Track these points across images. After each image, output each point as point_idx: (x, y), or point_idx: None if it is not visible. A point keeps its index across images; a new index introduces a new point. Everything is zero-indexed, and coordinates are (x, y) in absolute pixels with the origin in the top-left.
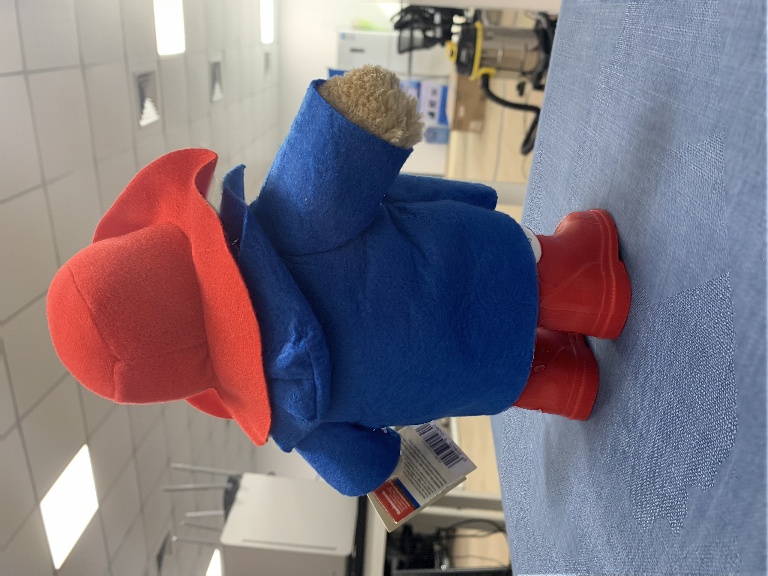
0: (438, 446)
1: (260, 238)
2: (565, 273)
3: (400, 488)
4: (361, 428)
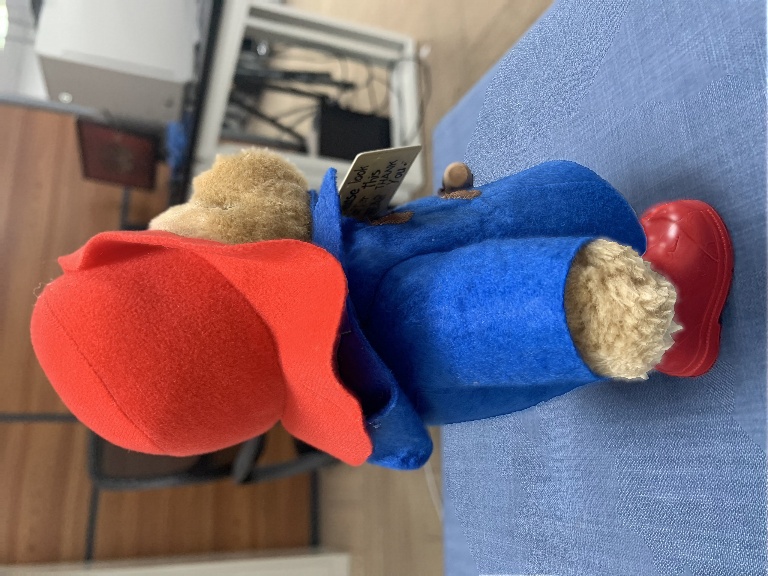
0: None
1: (402, 409)
2: None
3: None
4: None
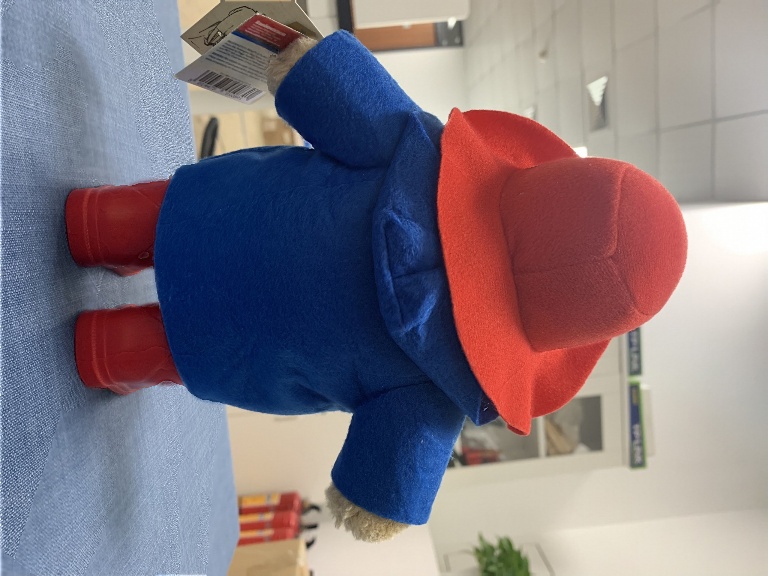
0: (229, 85)
1: (462, 407)
2: (156, 378)
3: (264, 43)
4: (330, 158)
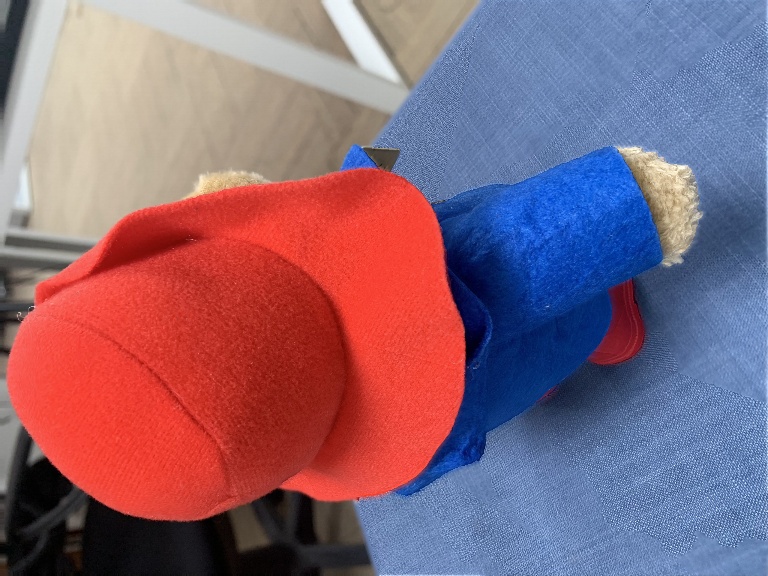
0: None
1: (487, 351)
2: (612, 321)
3: None
4: None
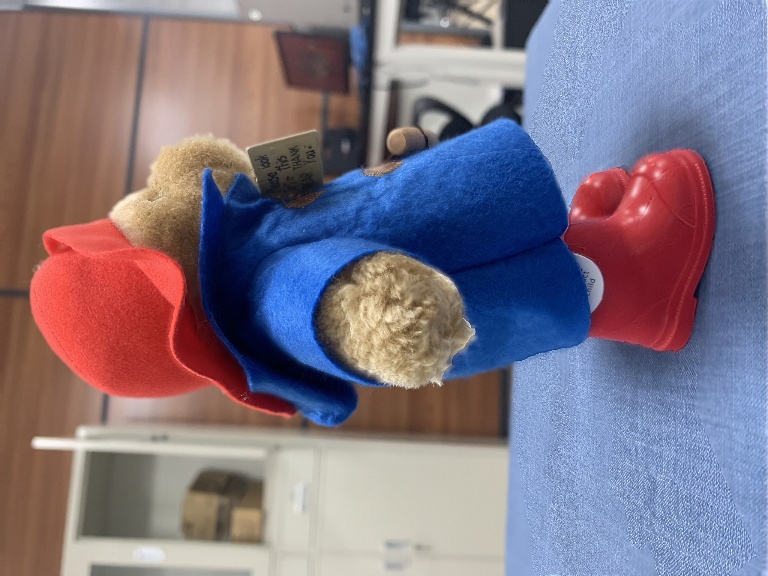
0: None
1: (270, 384)
2: (622, 318)
3: None
4: None
